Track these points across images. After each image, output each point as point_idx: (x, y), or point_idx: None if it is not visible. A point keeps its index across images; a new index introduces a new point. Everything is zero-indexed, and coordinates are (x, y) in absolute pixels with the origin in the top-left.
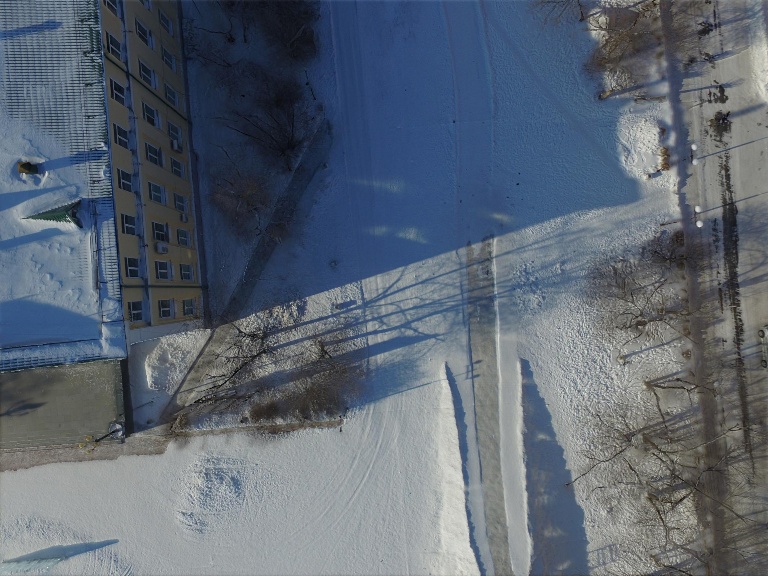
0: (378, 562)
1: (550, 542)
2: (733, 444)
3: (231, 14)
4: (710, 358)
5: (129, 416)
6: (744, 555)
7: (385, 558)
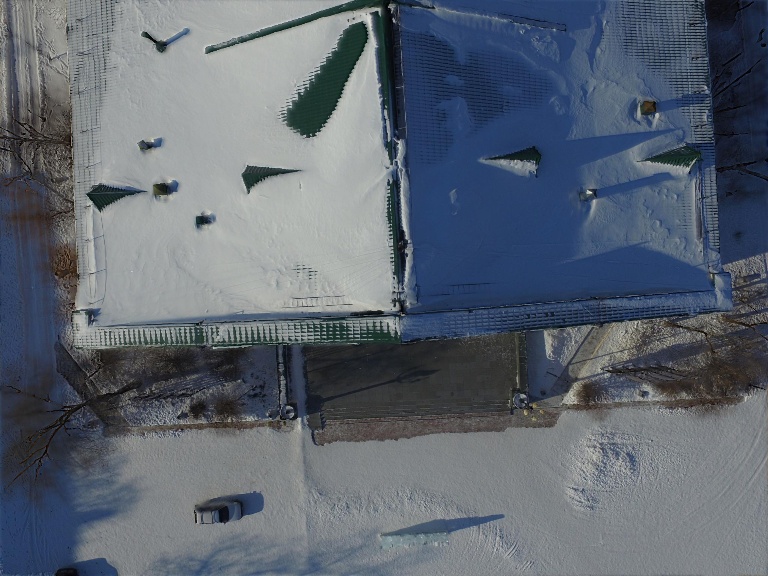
0: None
1: None
2: None
3: None
4: None
5: None
6: None
7: None
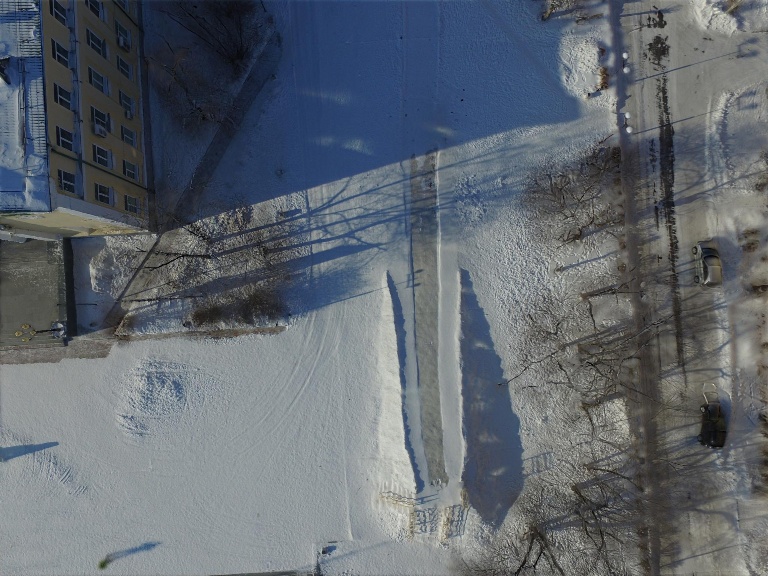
0: (316, 468)
1: (485, 448)
2: (652, 333)
3: None
4: (645, 274)
5: (72, 318)
6: (676, 467)
7: (323, 464)
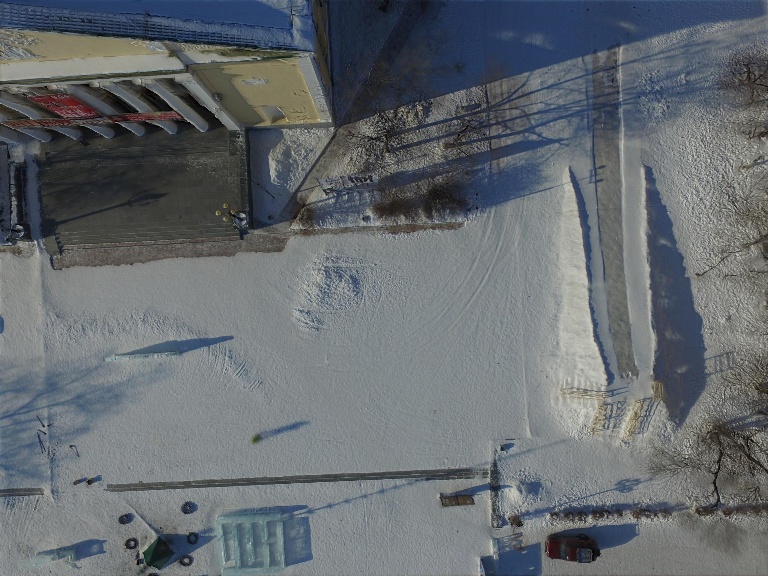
0: (494, 364)
1: (670, 345)
2: None
3: None
4: None
5: (250, 210)
6: None
7: (502, 361)
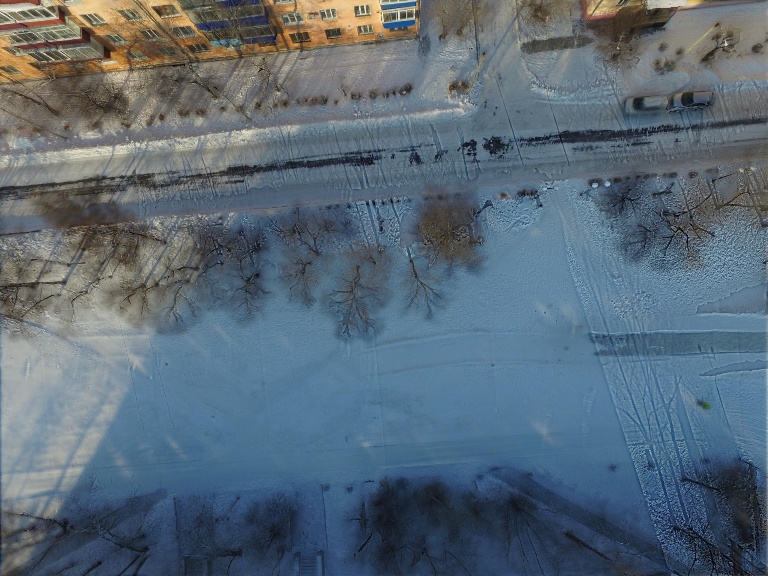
0: None
1: None
2: None
3: (420, 557)
4: (691, 152)
5: None
6: None
7: None
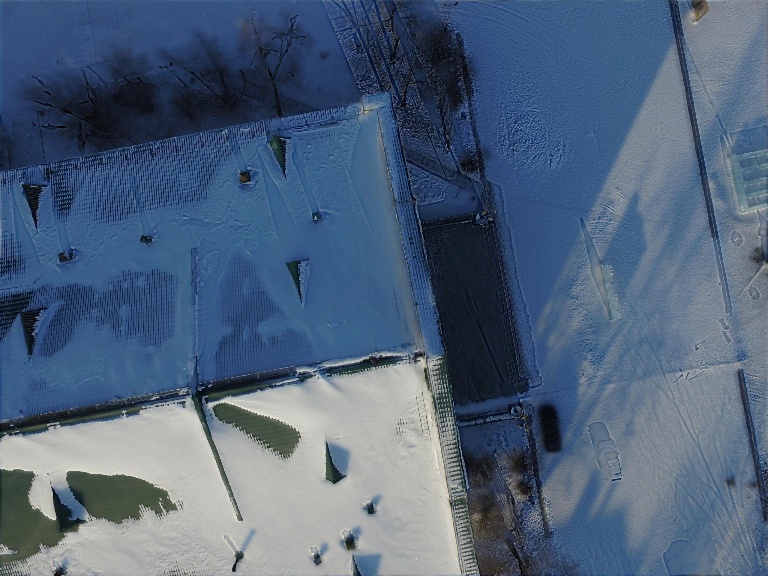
0: None
1: None
2: None
3: (119, 144)
4: None
5: None
6: None
7: None
